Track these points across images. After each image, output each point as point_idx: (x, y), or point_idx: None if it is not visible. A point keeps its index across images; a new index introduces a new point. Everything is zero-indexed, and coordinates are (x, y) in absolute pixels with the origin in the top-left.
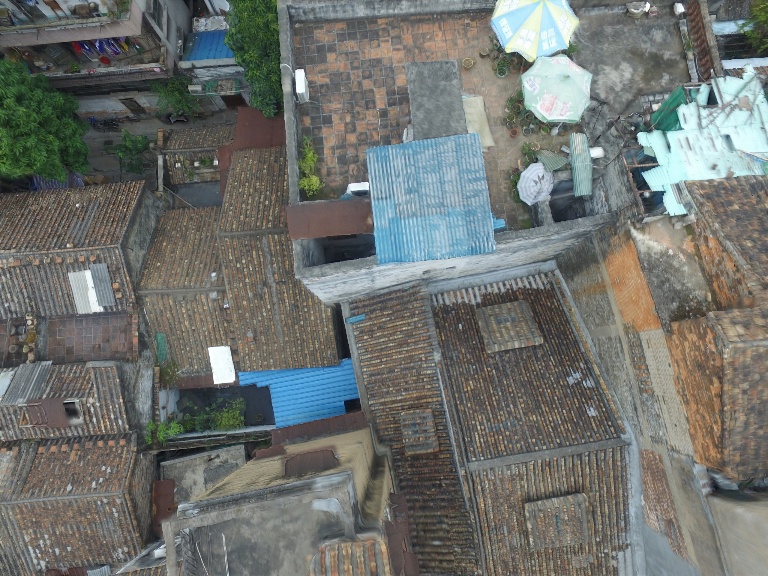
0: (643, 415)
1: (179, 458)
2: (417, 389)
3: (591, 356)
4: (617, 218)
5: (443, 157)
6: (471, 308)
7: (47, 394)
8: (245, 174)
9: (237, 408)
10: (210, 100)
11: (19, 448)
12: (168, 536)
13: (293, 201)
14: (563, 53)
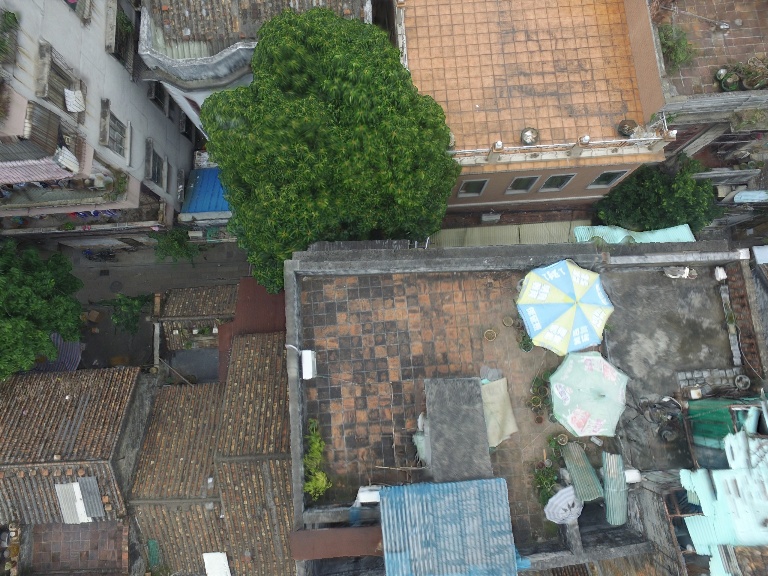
0: None
1: None
2: None
3: None
4: (654, 552)
5: (465, 506)
6: None
7: None
8: (246, 371)
9: None
10: None
11: None
12: None
13: (297, 513)
14: (596, 350)
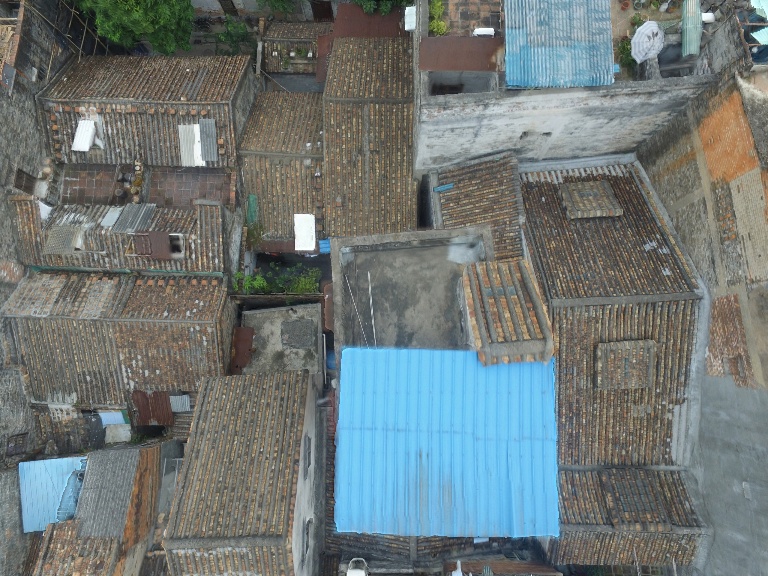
0: (721, 264)
1: (259, 309)
2: (499, 250)
3: (667, 229)
4: (720, 78)
5: None
6: (553, 186)
7: (153, 228)
8: (347, 56)
9: (313, 275)
10: (301, 8)
11: (119, 279)
12: (335, 249)
13: None
14: None
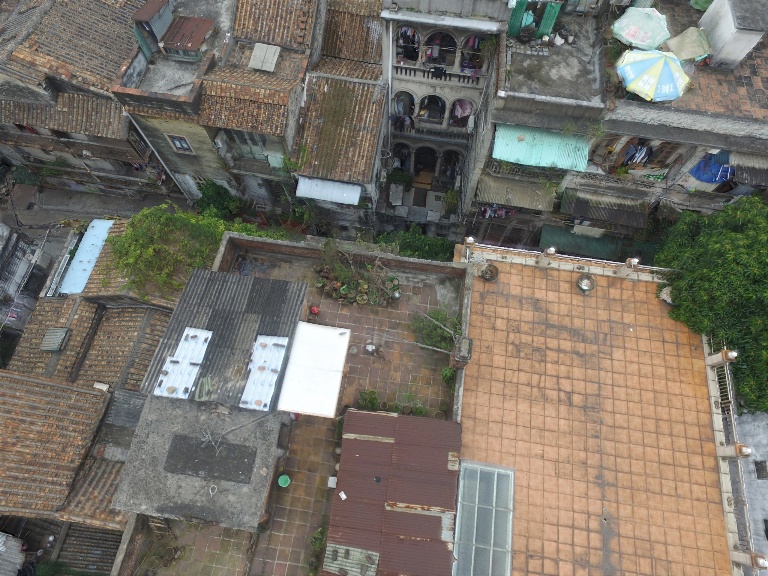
0: None
1: None
2: None
3: None
4: None
5: None
6: None
7: None
8: None
9: None
10: None
11: None
12: None
13: None
14: (635, 47)
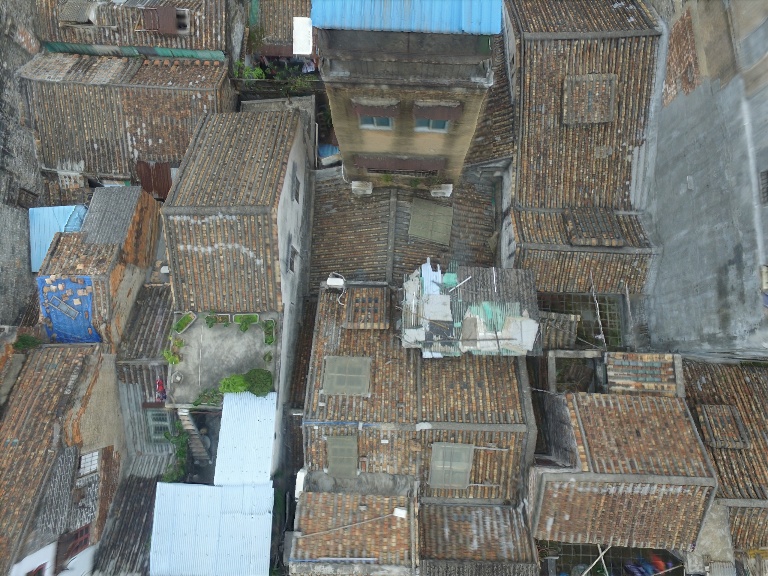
0: None
1: (257, 100)
2: None
3: None
4: None
5: None
6: None
7: None
8: None
9: None
10: None
11: (128, 59)
12: None
13: None
14: None
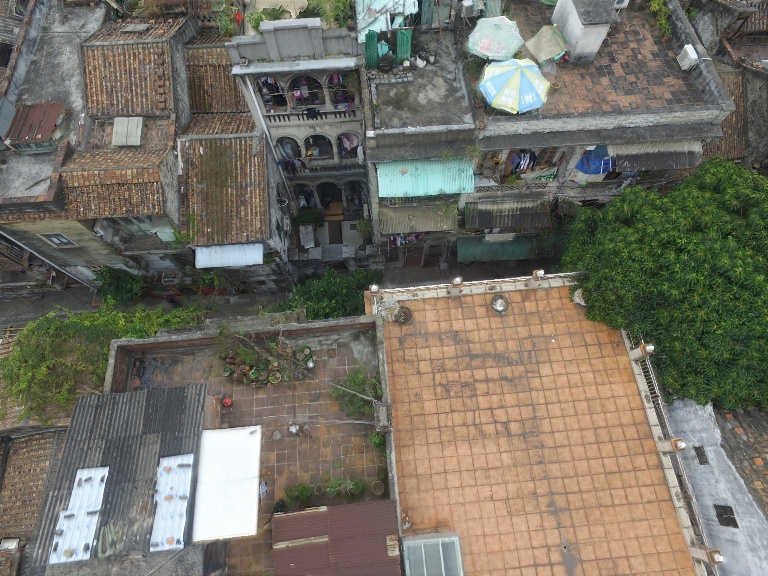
0: None
1: None
2: None
3: None
4: None
5: None
6: None
7: None
8: None
9: None
10: None
11: None
12: None
13: None
14: (492, 60)
